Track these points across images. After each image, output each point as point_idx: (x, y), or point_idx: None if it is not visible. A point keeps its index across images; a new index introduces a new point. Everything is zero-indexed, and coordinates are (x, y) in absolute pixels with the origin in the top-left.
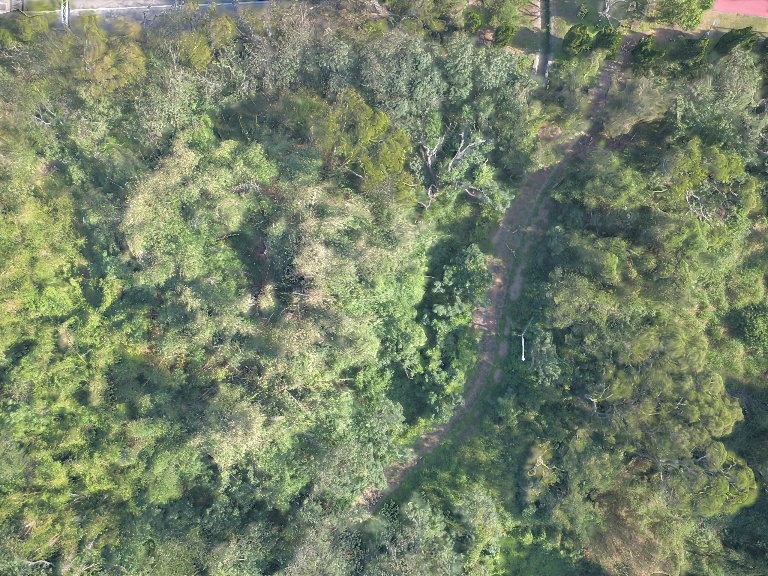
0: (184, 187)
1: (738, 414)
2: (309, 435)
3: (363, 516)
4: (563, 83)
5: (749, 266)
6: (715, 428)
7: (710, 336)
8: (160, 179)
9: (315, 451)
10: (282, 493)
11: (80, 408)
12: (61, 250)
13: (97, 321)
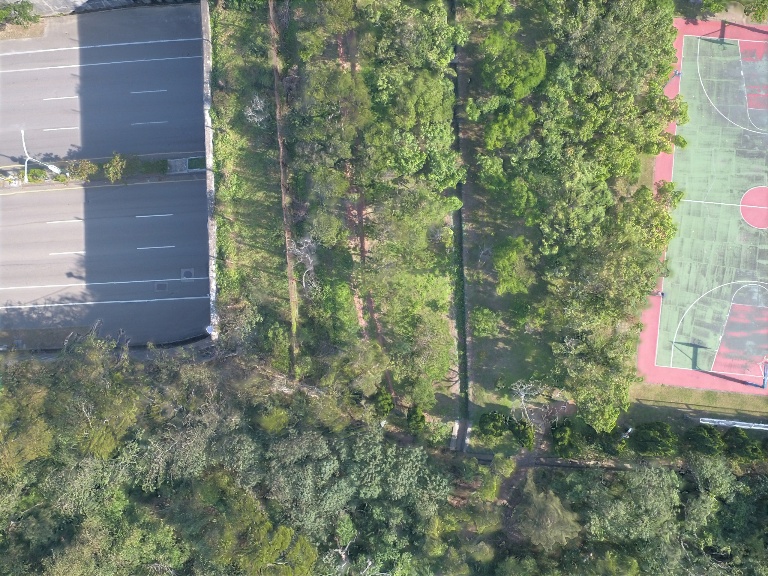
0: (99, 568)
1: None
2: None
3: None
4: None
5: None
6: None
7: None
8: (75, 558)
9: None
10: None
11: None
12: None
13: None
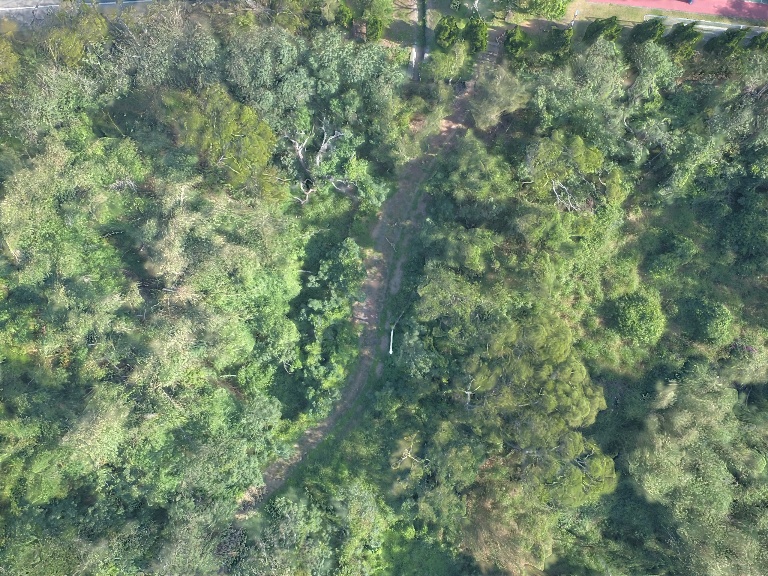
0: (60, 185)
1: (600, 404)
2: (188, 432)
3: (249, 513)
4: (434, 75)
5: (624, 256)
6: (572, 418)
7: (586, 327)
8: (37, 177)
9: None
10: (157, 491)
11: None
12: None
13: None
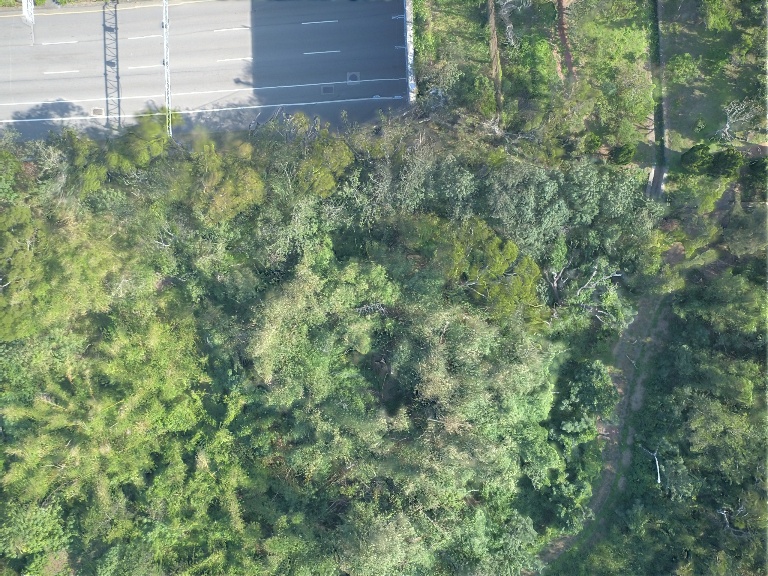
0: (310, 311)
1: None
2: (441, 550)
3: None
4: (684, 201)
5: None
6: None
7: None
8: (285, 303)
9: (447, 565)
10: None
11: (213, 524)
12: (185, 369)
13: (224, 437)
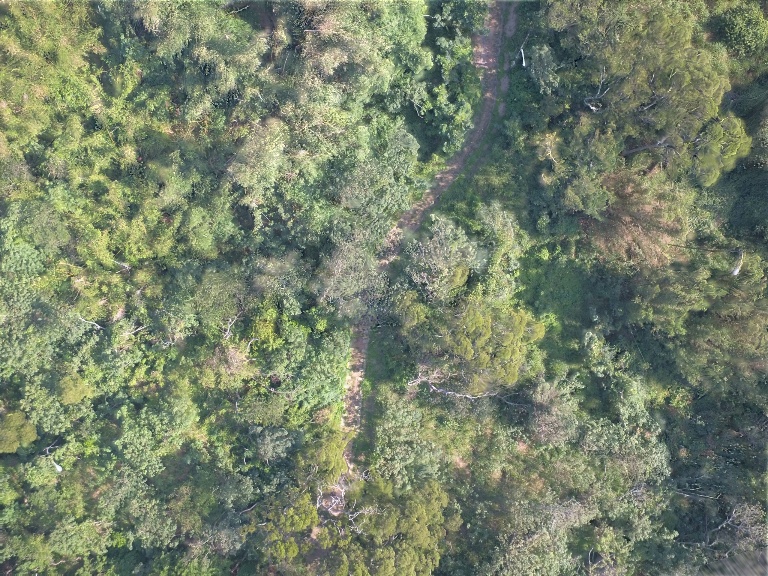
0: None
1: (726, 83)
2: (331, 175)
3: (389, 258)
4: None
5: None
6: (705, 88)
7: (694, 43)
8: None
9: None
10: (312, 222)
11: (113, 182)
12: (80, 41)
13: (121, 103)
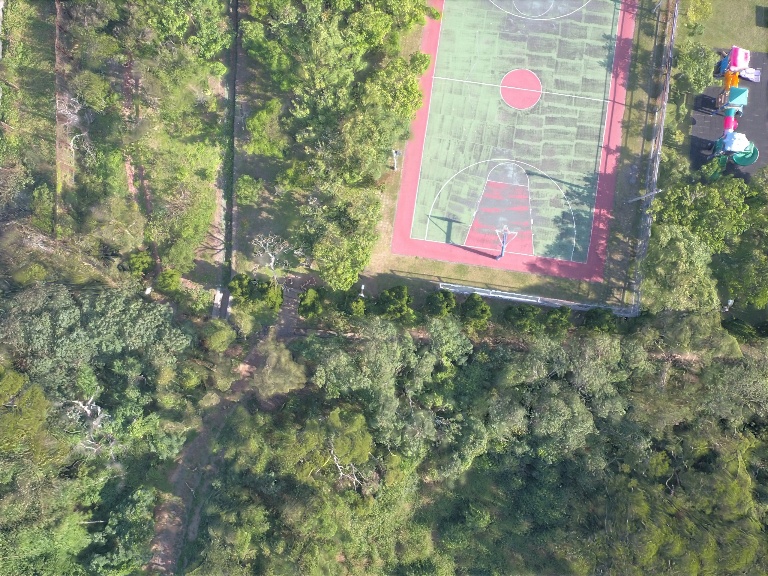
0: None
1: None
2: None
3: None
4: None
5: (419, 521)
6: None
7: None
8: None
9: None
10: None
11: None
12: None
13: None
